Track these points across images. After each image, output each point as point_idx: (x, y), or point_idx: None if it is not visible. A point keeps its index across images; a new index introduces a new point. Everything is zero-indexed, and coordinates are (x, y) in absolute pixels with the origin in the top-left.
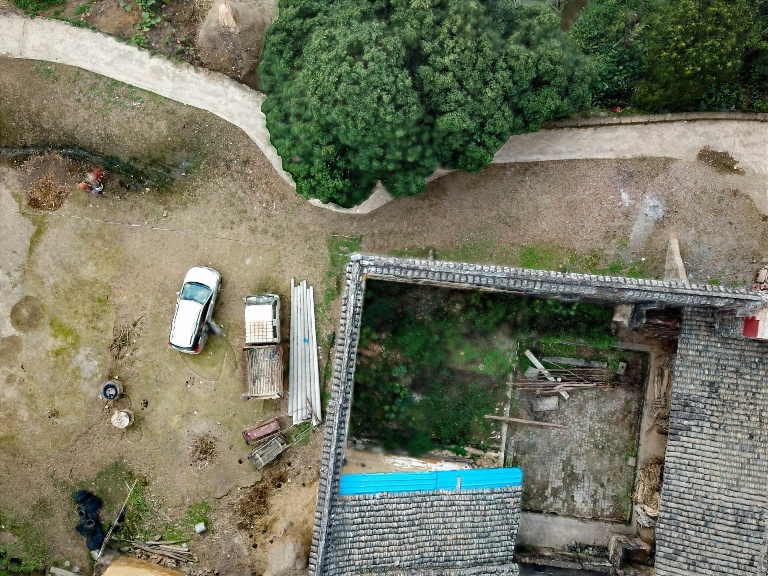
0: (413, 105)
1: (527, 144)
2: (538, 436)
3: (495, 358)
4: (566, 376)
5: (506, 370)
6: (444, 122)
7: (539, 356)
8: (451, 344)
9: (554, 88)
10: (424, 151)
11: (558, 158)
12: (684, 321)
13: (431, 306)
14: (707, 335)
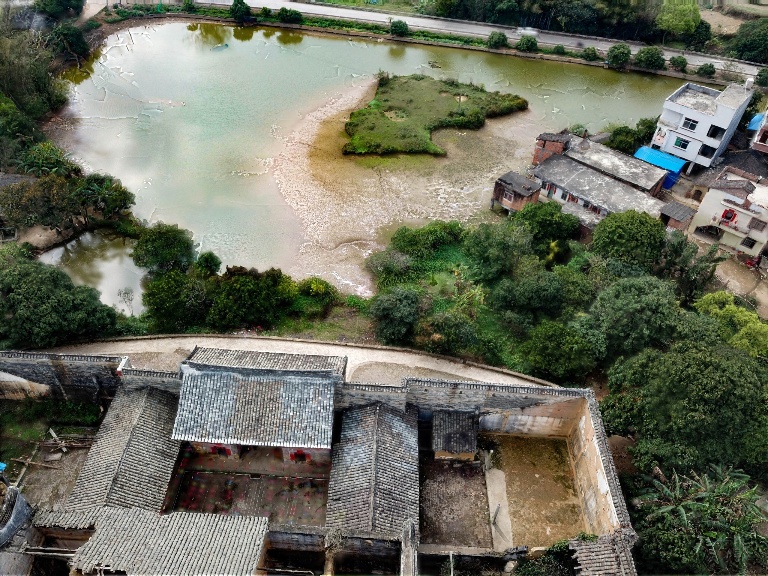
0: (0, 304)
1: (90, 349)
2: (43, 475)
3: (30, 433)
4: (69, 441)
5: (35, 439)
6: (17, 314)
7: (58, 433)
8: (7, 426)
9: (84, 311)
10: (10, 330)
11: (103, 354)
12: (116, 392)
13: (5, 410)
14: (123, 395)
